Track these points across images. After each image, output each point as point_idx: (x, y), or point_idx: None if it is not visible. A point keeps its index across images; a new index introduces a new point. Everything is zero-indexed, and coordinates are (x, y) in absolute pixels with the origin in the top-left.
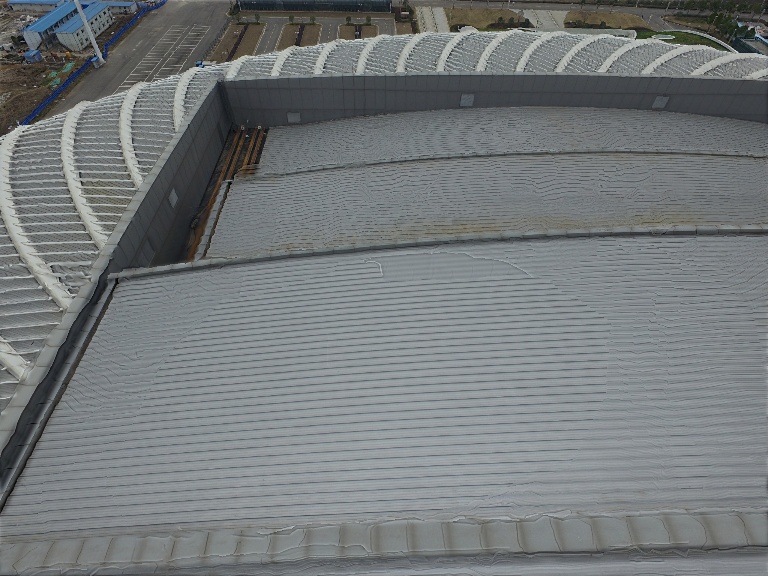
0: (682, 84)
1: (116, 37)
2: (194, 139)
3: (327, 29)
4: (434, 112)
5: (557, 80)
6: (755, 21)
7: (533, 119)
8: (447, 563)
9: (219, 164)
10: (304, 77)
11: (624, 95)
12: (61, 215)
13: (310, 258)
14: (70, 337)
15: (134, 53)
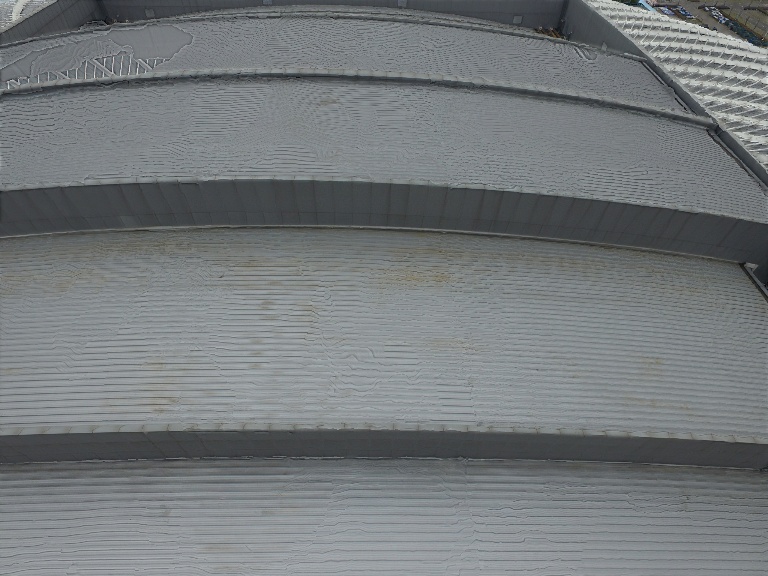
0: None
1: None
2: (64, 12)
3: None
4: (246, 9)
5: None
6: None
7: None
8: (74, 93)
9: None
10: None
11: None
12: None
13: (83, 34)
14: None
15: None
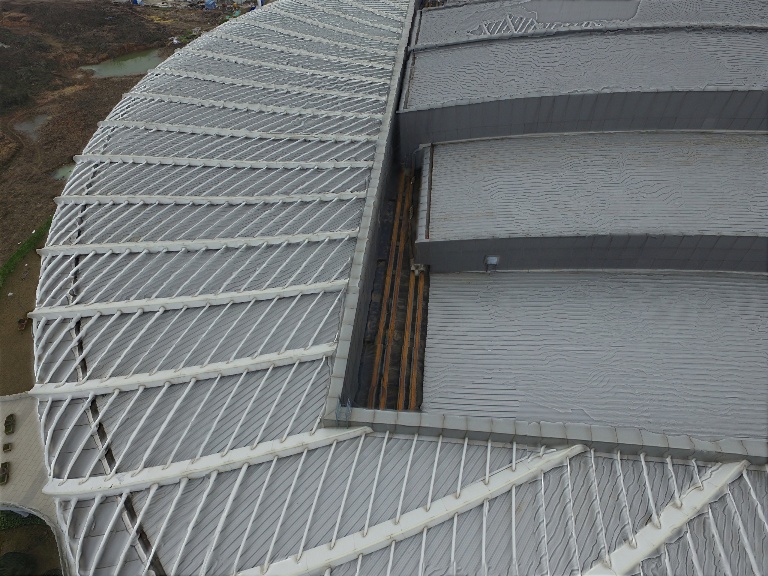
0: None
1: None
2: None
3: None
4: None
5: None
6: None
7: None
8: (581, 37)
9: None
10: None
11: None
12: (375, 2)
13: (510, 0)
14: (413, 21)
15: None
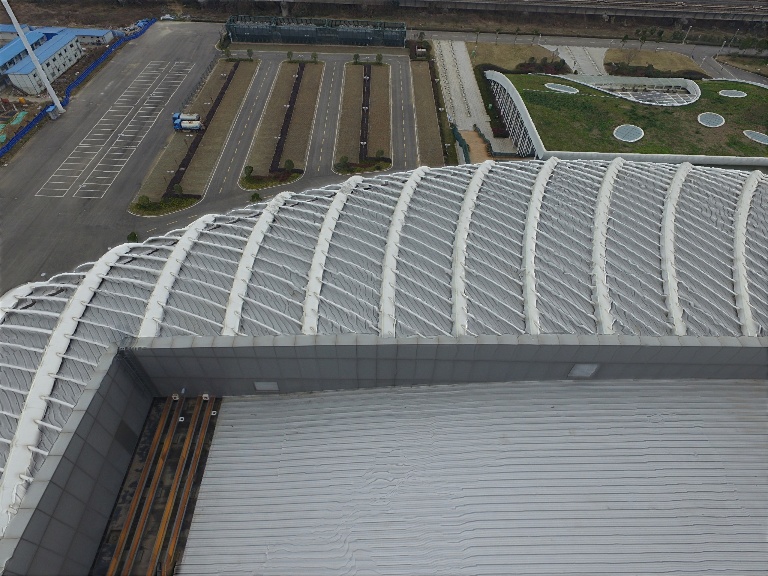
0: None
1: (82, 76)
2: (30, 566)
3: (331, 69)
4: (520, 386)
5: (759, 353)
6: None
7: (705, 411)
8: None
9: (115, 517)
10: (283, 345)
11: None
12: None
13: None
14: None
15: (101, 99)
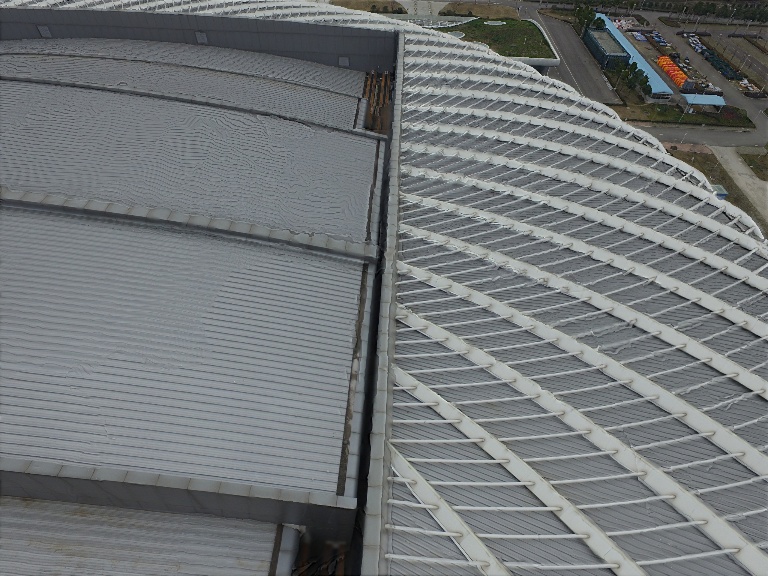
0: (207, 21)
1: None
2: None
3: None
4: (22, 41)
5: (103, 15)
6: (629, 16)
7: (92, 47)
8: None
9: None
10: None
11: (167, 30)
12: None
13: None
14: None
15: None
